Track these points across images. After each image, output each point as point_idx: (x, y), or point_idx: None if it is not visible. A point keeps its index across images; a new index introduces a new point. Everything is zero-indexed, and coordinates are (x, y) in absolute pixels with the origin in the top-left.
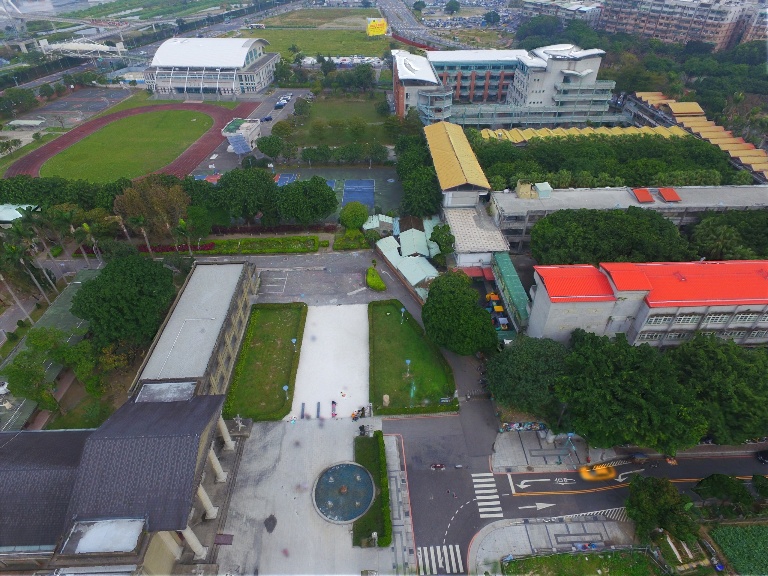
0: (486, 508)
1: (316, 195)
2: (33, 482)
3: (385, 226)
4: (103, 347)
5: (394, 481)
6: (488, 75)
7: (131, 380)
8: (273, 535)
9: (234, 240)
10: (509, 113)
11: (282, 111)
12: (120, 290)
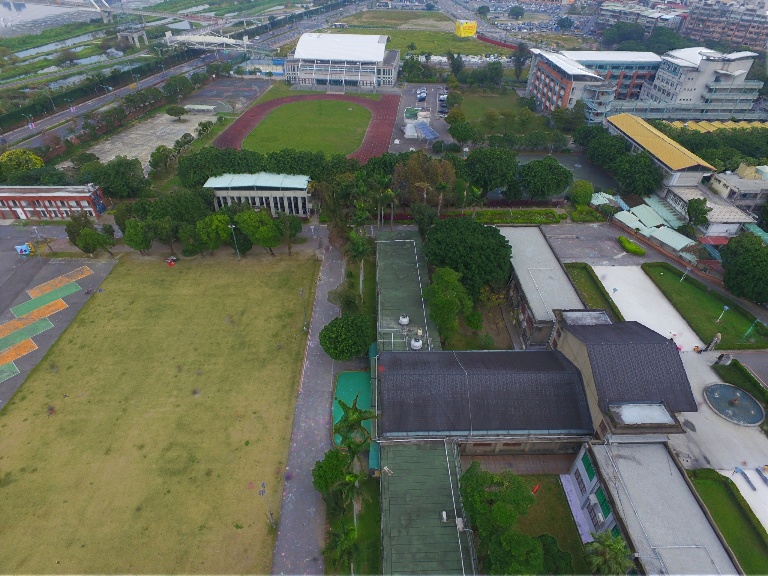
0: None
1: (558, 172)
2: (520, 383)
3: (613, 202)
4: (480, 288)
5: None
6: (622, 74)
7: (485, 319)
8: (699, 433)
9: (481, 211)
10: (661, 109)
11: (427, 103)
12: (482, 241)
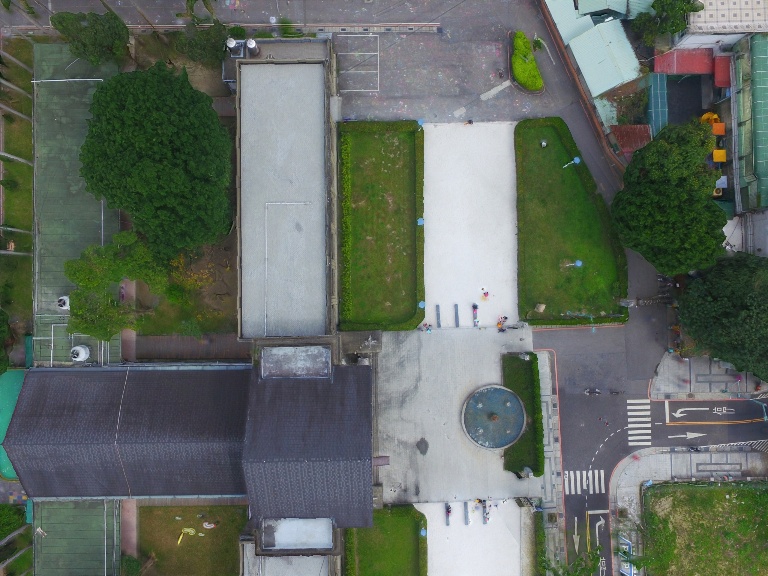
0: (636, 437)
1: None
2: (186, 452)
3: None
4: (170, 259)
5: (545, 407)
6: None
7: None
8: (427, 457)
9: None
10: None
11: None
12: (157, 179)
